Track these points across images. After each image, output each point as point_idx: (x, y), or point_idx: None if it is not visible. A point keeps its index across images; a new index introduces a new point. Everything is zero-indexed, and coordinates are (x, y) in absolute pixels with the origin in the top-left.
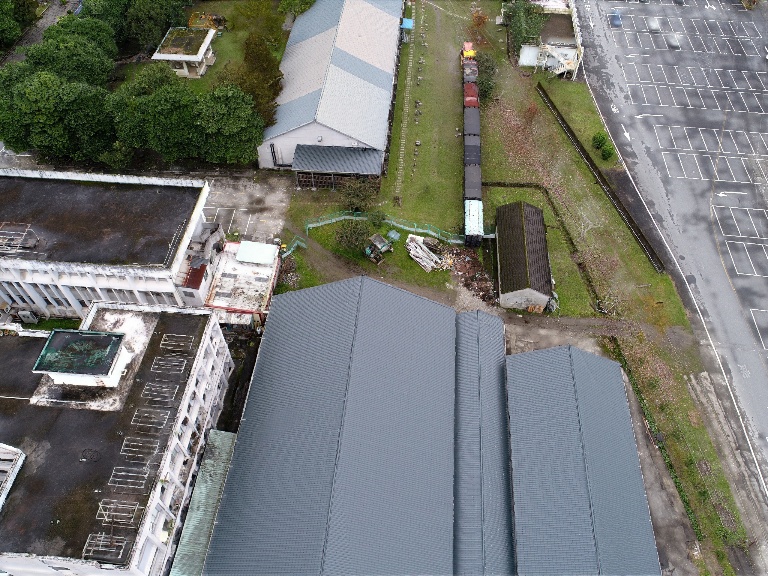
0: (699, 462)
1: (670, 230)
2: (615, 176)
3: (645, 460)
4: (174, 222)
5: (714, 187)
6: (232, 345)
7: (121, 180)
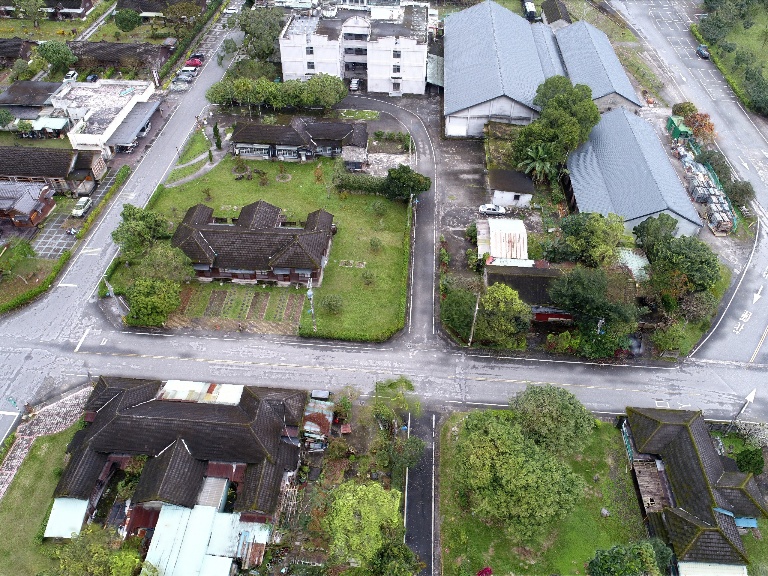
0: (642, 71)
1: (628, 17)
2: (600, 3)
3: None
4: None
5: (651, 6)
6: None
7: None
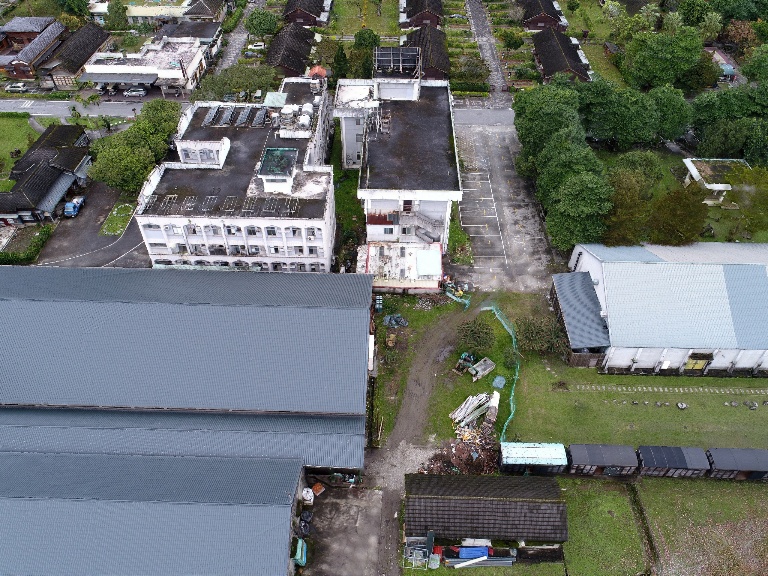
0: None
1: None
2: None
3: None
4: (416, 187)
5: None
6: None
7: None
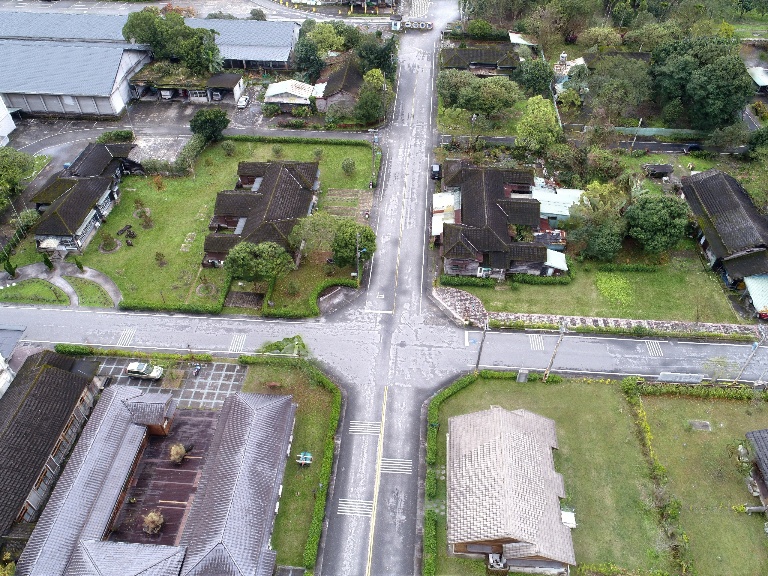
0: None
1: None
2: None
3: None
4: None
5: None
6: None
7: None
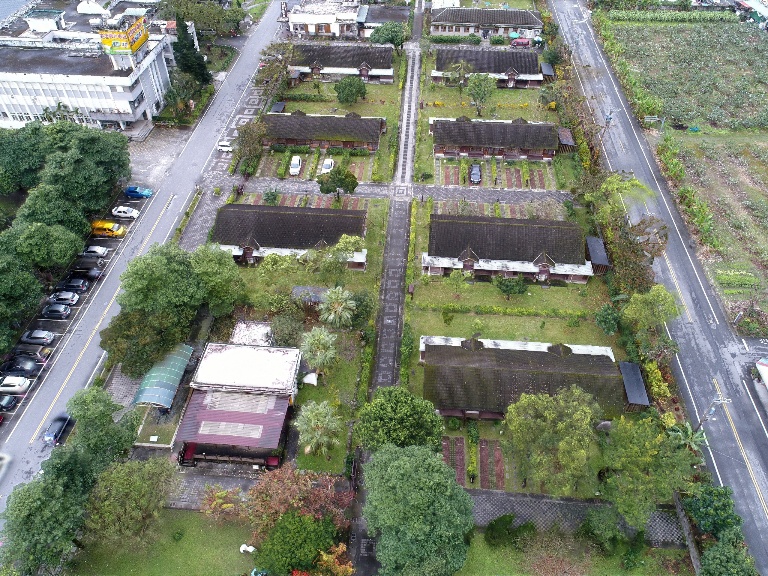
0: None
1: None
2: None
3: None
4: None
5: None
6: None
7: (10, 76)
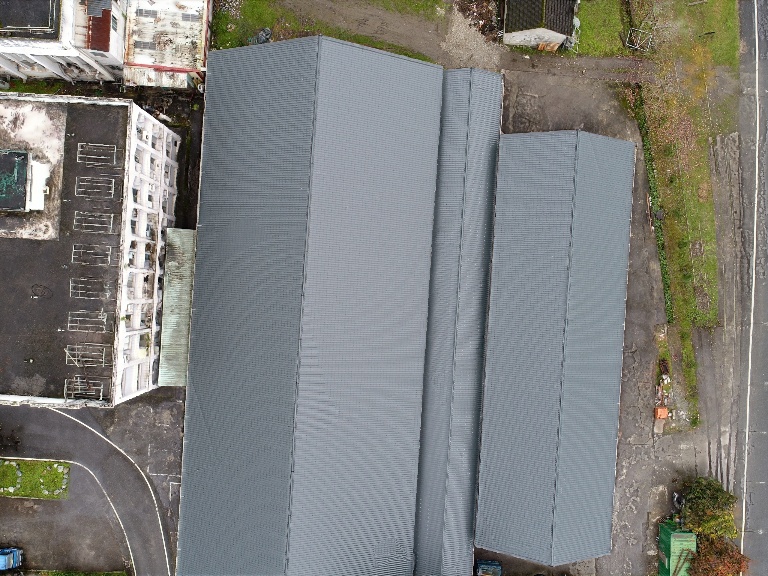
0: (694, 242)
1: None
2: None
3: (637, 243)
4: None
5: None
6: (172, 109)
7: None
